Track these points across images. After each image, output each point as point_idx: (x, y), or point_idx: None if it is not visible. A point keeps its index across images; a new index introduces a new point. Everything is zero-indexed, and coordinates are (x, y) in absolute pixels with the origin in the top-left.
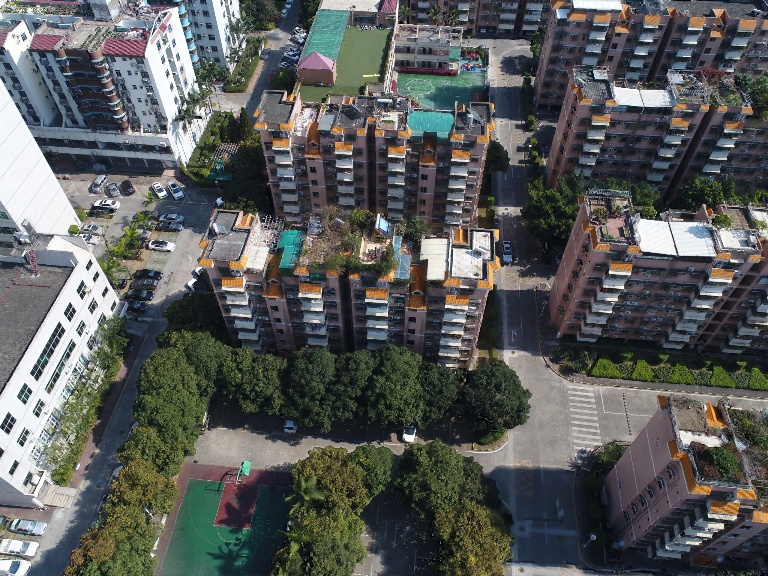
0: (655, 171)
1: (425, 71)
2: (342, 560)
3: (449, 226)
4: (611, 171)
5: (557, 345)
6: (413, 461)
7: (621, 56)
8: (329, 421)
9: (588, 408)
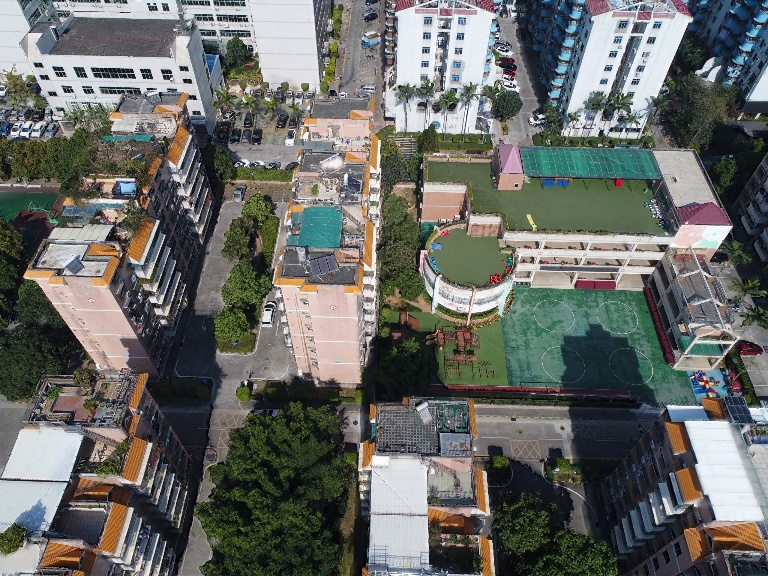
0: None
1: (656, 320)
2: None
3: None
4: None
5: None
6: None
7: None
8: None
9: None
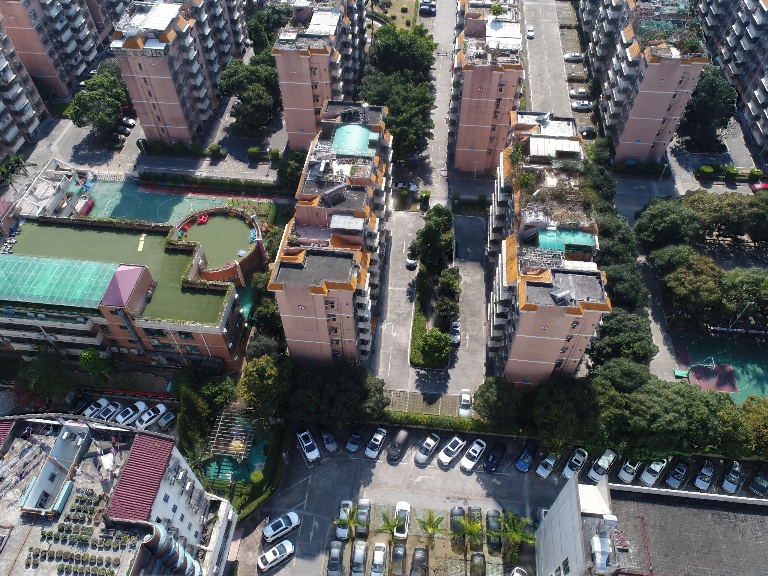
0: (350, 69)
1: None
2: (761, 268)
3: (391, 211)
4: None
5: None
6: (673, 226)
7: (200, 45)
8: None
9: None
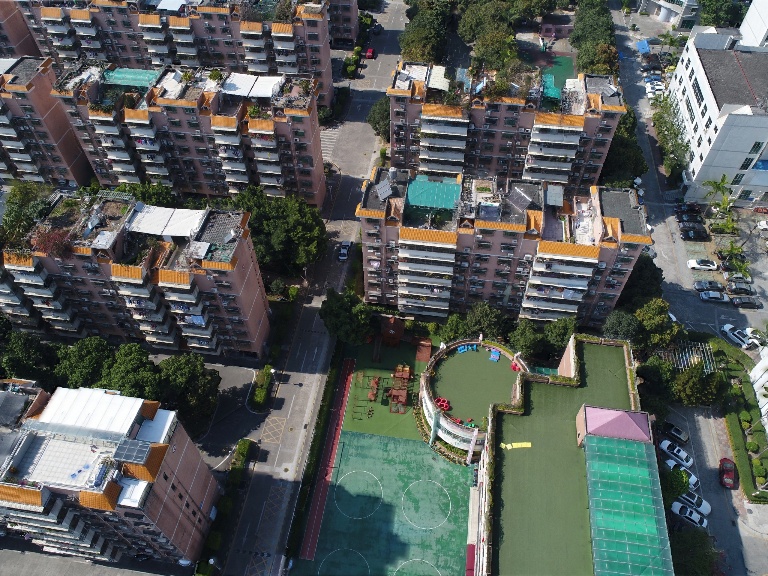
0: None
1: None
2: None
3: None
4: None
5: (327, 180)
6: None
7: None
8: None
9: None
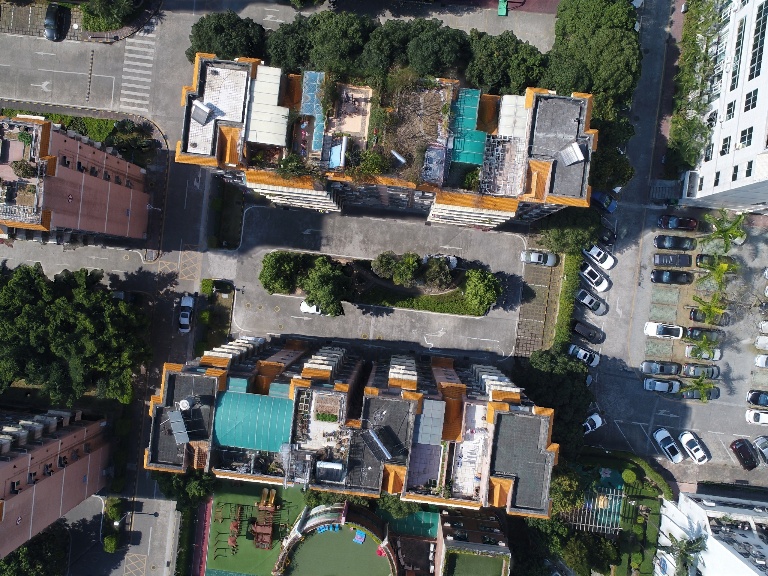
0: None
1: None
2: None
3: None
4: (2, 425)
5: None
6: None
7: None
8: (414, 22)
9: (131, 82)
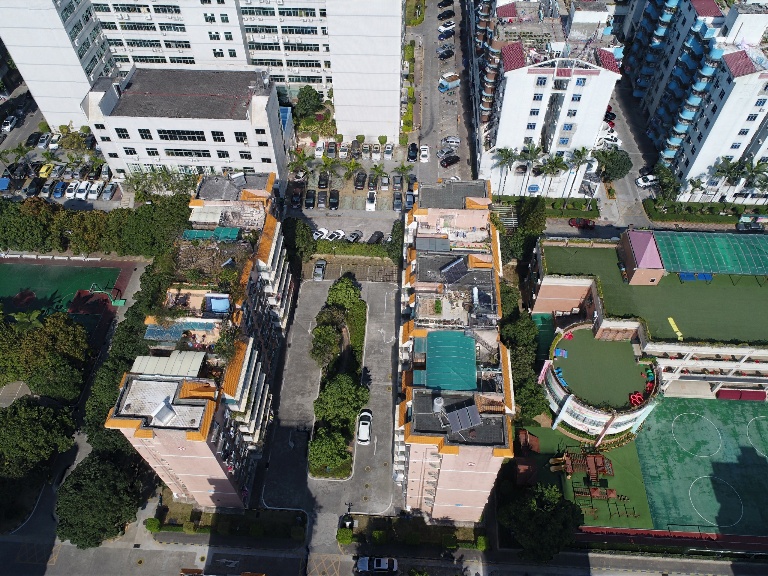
0: None
1: None
2: None
3: None
4: None
5: None
6: None
7: None
8: None
9: None
